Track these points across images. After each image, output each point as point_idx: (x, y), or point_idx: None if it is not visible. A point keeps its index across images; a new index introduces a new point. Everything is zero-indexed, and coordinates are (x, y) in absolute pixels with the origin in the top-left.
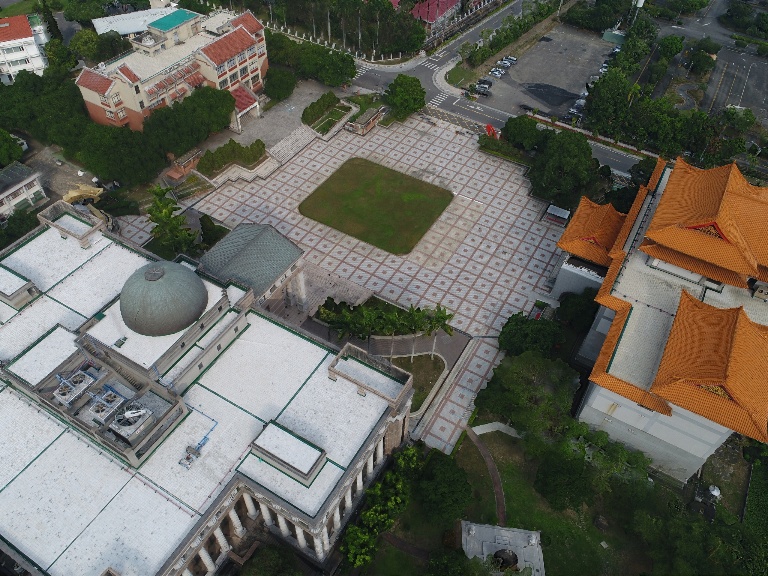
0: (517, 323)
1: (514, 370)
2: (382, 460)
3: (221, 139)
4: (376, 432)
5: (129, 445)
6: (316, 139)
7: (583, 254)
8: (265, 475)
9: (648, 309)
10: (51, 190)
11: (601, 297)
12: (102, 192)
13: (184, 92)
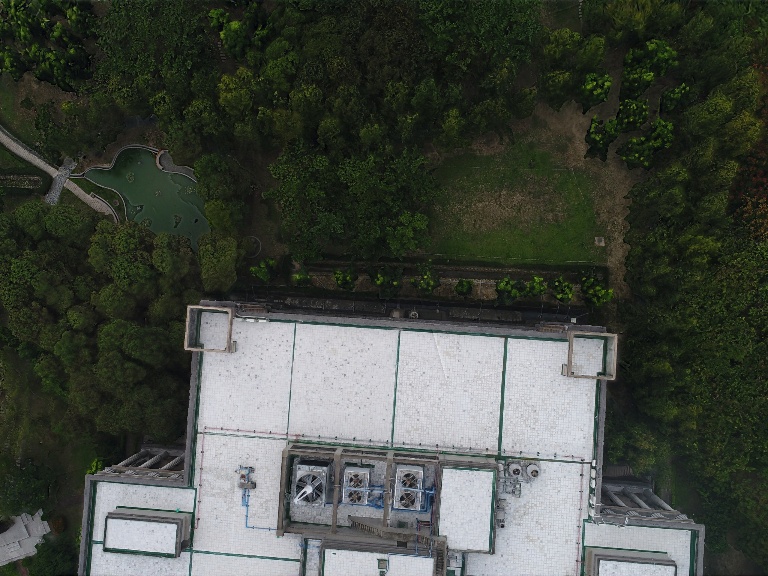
0: None
1: None
2: None
3: None
4: None
5: (307, 460)
6: None
7: None
8: (165, 498)
9: None
10: None
11: None
12: None
13: None
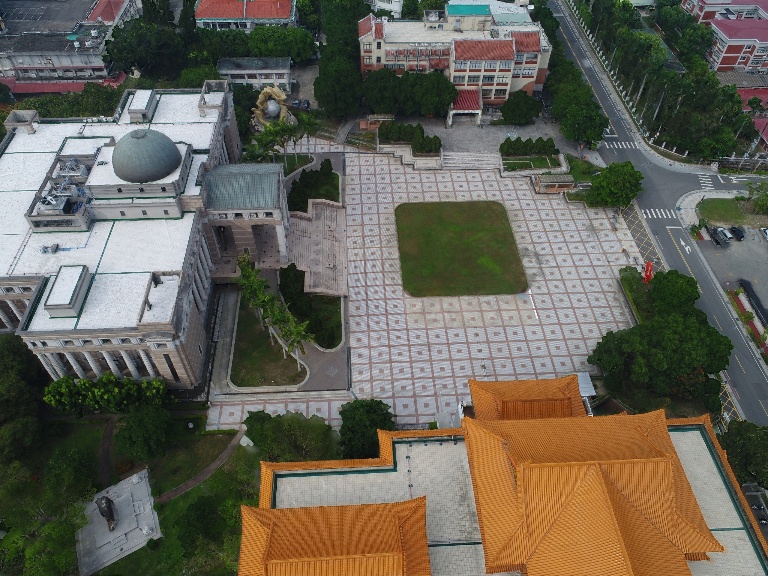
0: (366, 406)
1: (291, 421)
2: (153, 376)
3: (429, 123)
4: (111, 330)
5: None
6: (496, 170)
7: (479, 410)
8: None
9: (404, 487)
10: (299, 89)
11: (384, 433)
12: (284, 99)
13: (425, 69)
